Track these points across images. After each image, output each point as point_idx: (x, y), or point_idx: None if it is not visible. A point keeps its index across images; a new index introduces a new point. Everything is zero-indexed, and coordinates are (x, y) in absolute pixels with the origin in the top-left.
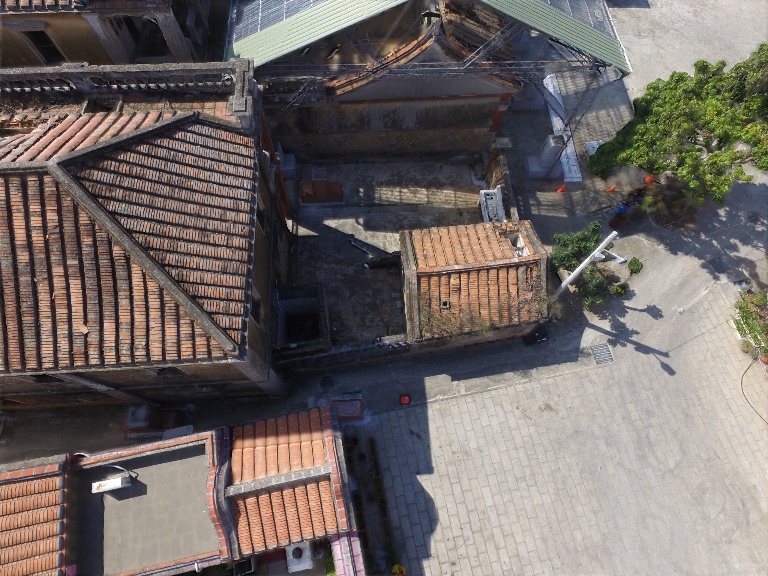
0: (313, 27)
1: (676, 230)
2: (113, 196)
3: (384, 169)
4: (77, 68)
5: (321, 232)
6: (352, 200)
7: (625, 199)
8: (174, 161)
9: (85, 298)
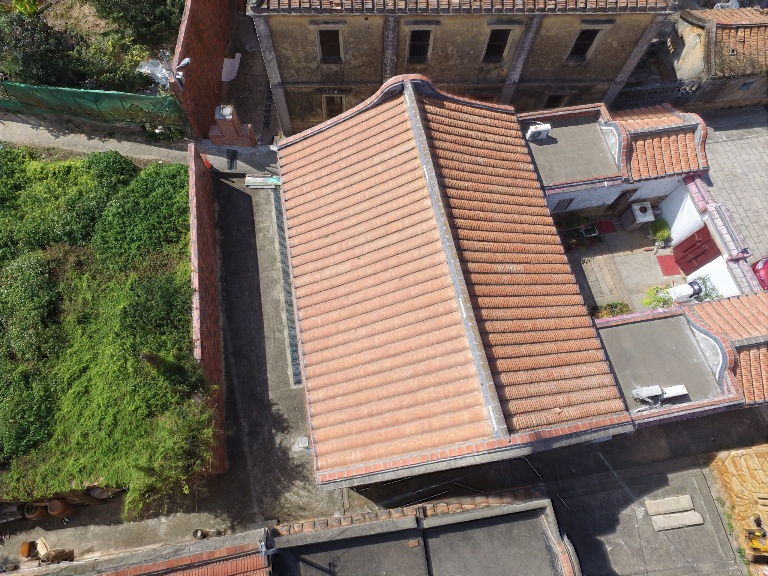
0: None
1: None
2: None
3: None
4: None
5: None
6: None
7: None
8: None
9: None
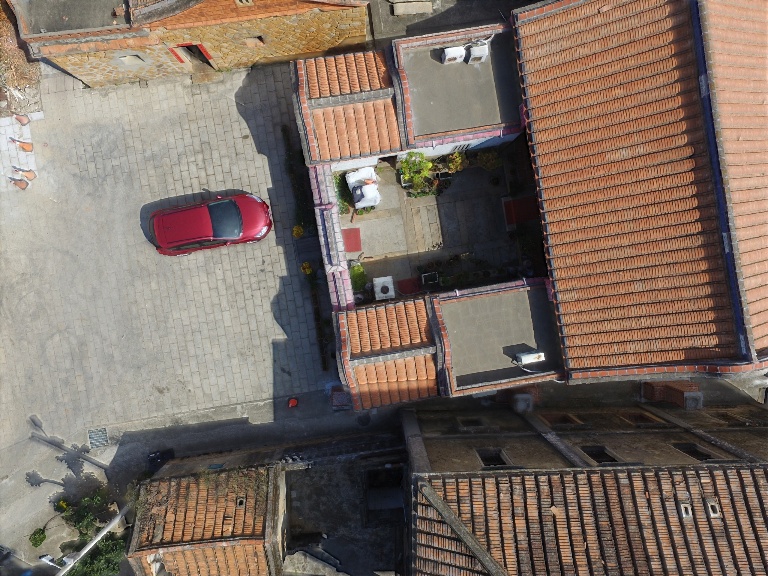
0: None
1: None
2: None
3: None
4: None
5: (371, 575)
6: None
7: None
8: None
9: (557, 542)
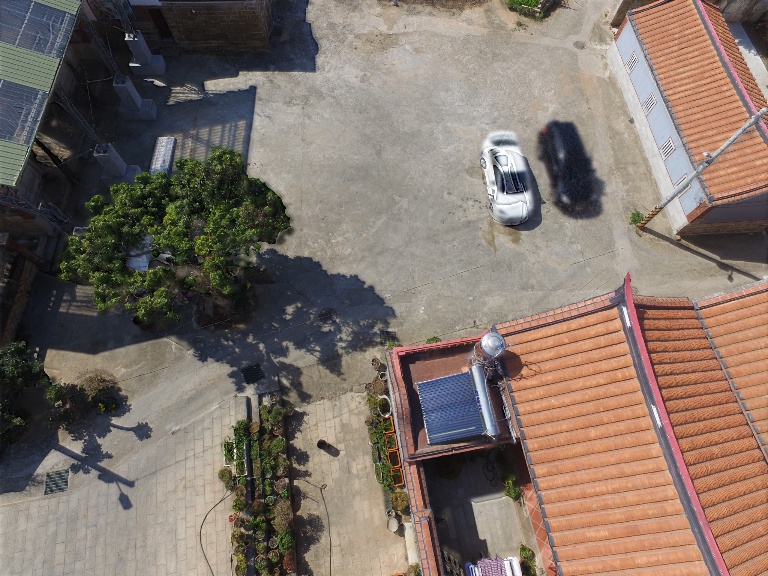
0: None
1: (218, 332)
2: None
3: None
4: None
5: None
6: None
7: None
8: None
9: None
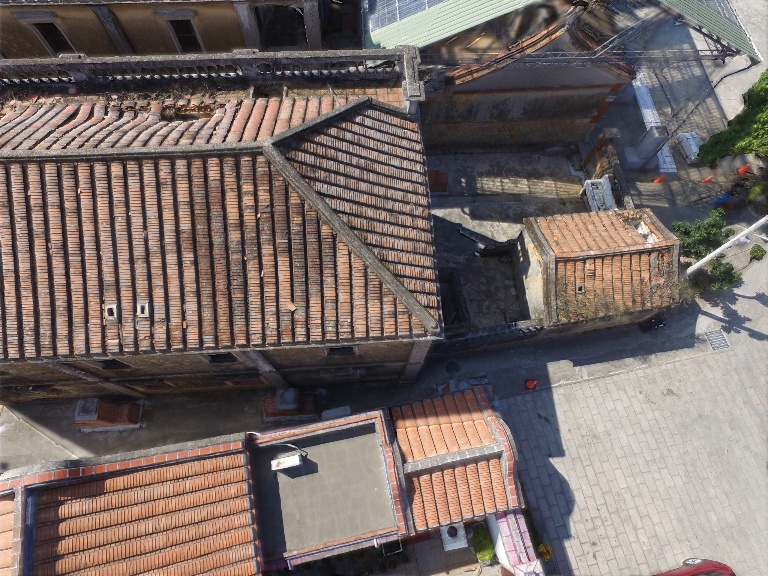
0: (463, 15)
1: None
2: (316, 177)
3: (483, 160)
4: (250, 54)
5: None
6: (455, 190)
7: (723, 189)
8: (358, 144)
9: (292, 276)
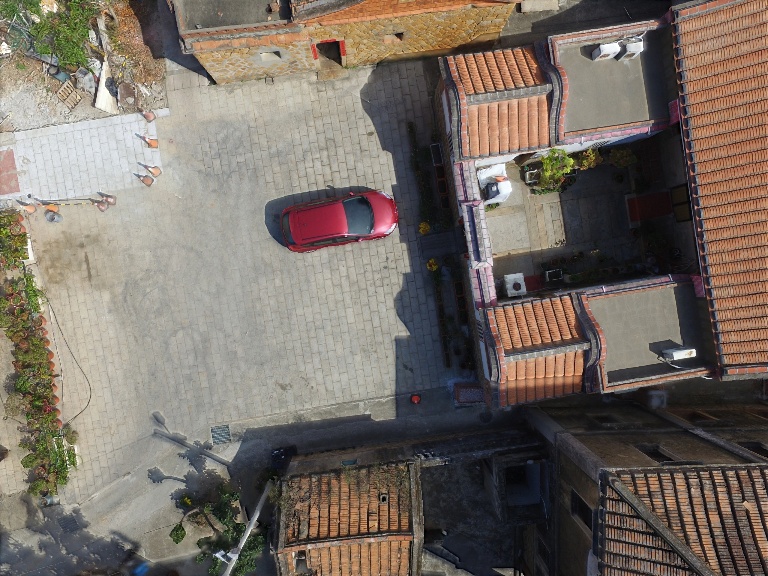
0: None
1: (104, 567)
2: None
3: None
4: None
5: (490, 572)
6: None
7: None
8: None
9: (754, 537)
